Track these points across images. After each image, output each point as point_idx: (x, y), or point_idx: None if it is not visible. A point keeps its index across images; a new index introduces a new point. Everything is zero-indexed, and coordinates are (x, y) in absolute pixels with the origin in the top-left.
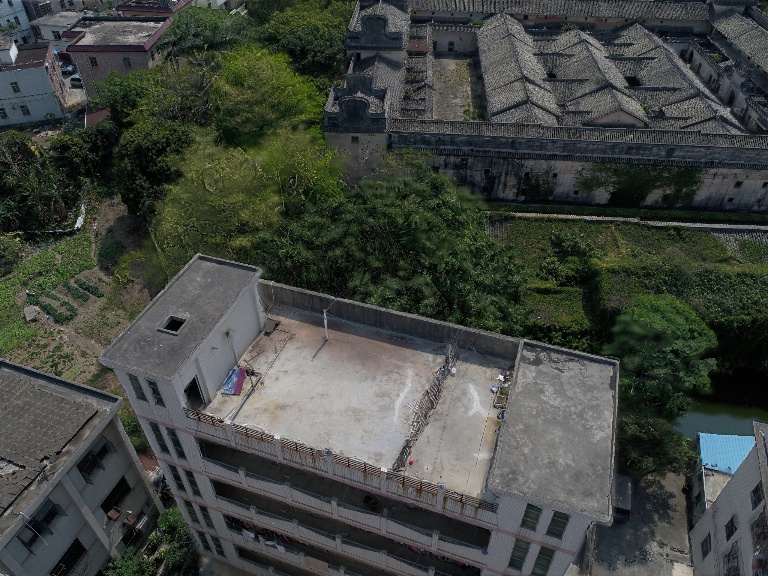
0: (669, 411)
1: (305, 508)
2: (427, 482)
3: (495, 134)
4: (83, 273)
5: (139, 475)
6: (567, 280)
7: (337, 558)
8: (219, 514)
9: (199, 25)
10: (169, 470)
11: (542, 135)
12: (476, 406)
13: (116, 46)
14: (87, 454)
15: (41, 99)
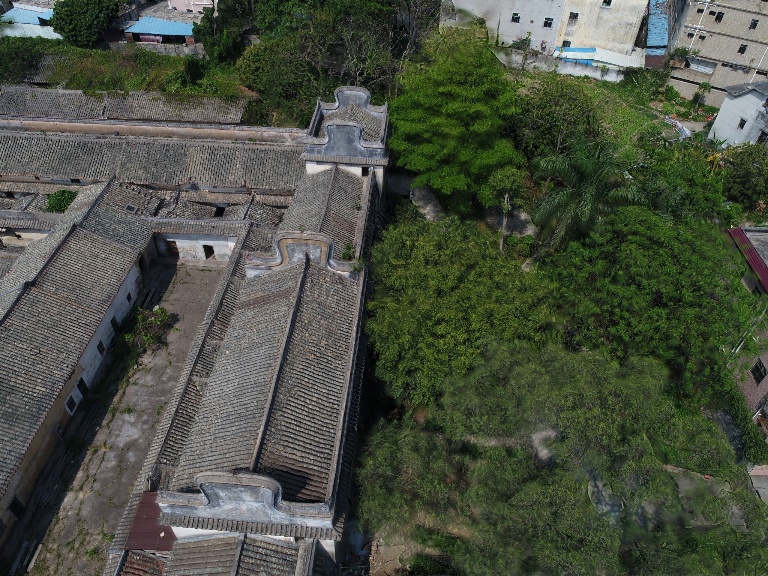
0: None
1: None
2: None
3: None
4: None
5: None
6: None
7: None
8: None
9: None
10: None
11: None
12: None
13: None
14: None
15: None
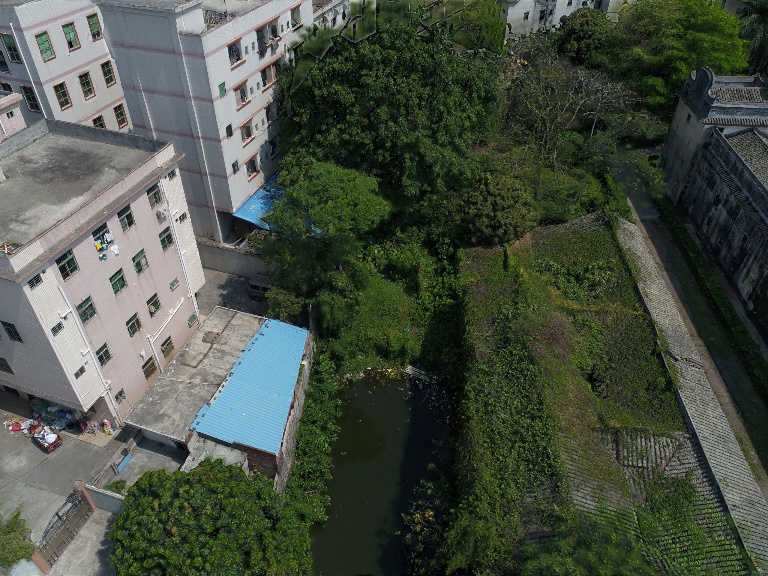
0: (317, 289)
1: None
2: None
3: None
4: None
5: None
6: None
7: None
8: None
9: None
10: None
11: None
12: None
13: None
14: None
15: None
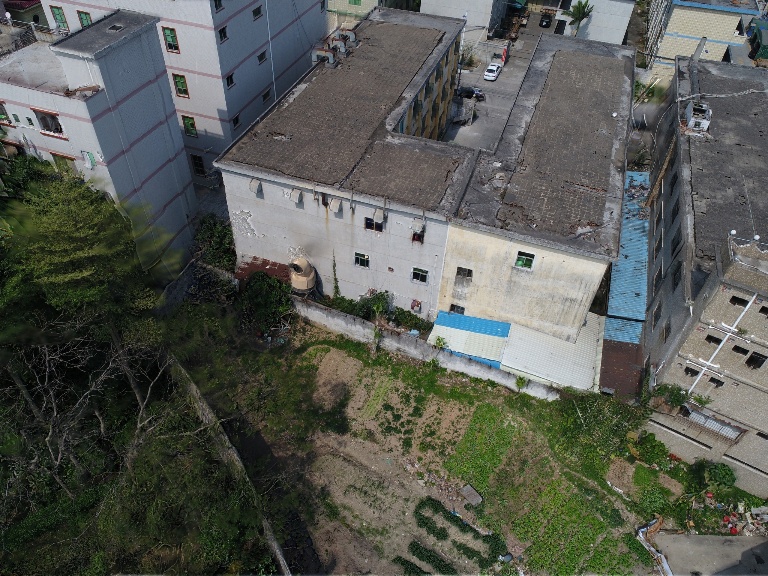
0: None
1: None
2: None
3: None
4: None
5: None
6: None
7: None
8: None
9: None
10: None
11: None
12: None
13: None
14: None
15: None
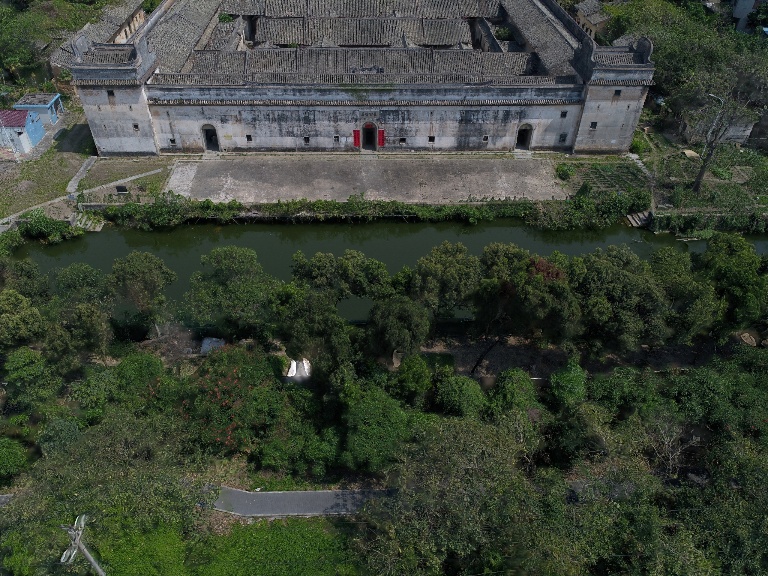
0: None
1: None
2: None
3: None
4: None
5: None
6: None
7: None
8: None
9: None
10: None
11: None
12: None
13: None
14: None
15: None
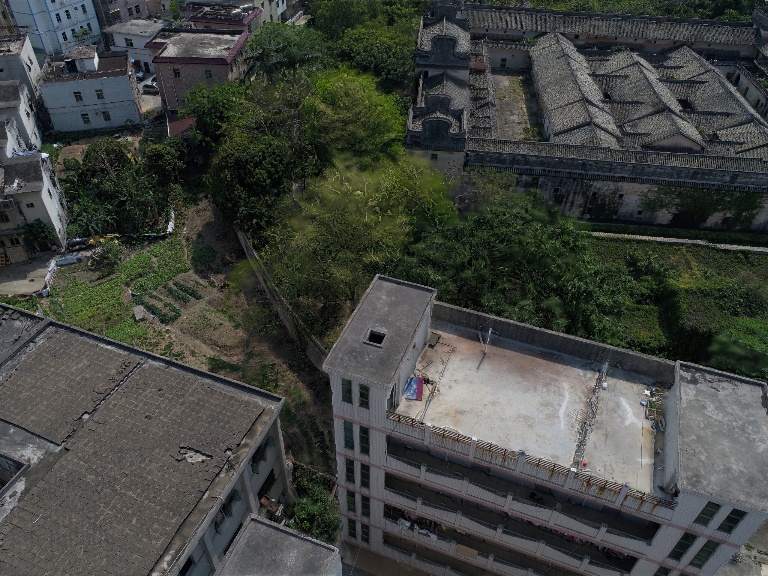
0: None
1: (478, 501)
2: (613, 482)
3: (566, 155)
4: (180, 276)
5: (283, 467)
6: (642, 298)
7: (491, 546)
8: (381, 504)
9: (280, 41)
10: (345, 464)
11: (610, 158)
12: (630, 417)
13: (200, 59)
14: (259, 447)
15: (122, 106)
